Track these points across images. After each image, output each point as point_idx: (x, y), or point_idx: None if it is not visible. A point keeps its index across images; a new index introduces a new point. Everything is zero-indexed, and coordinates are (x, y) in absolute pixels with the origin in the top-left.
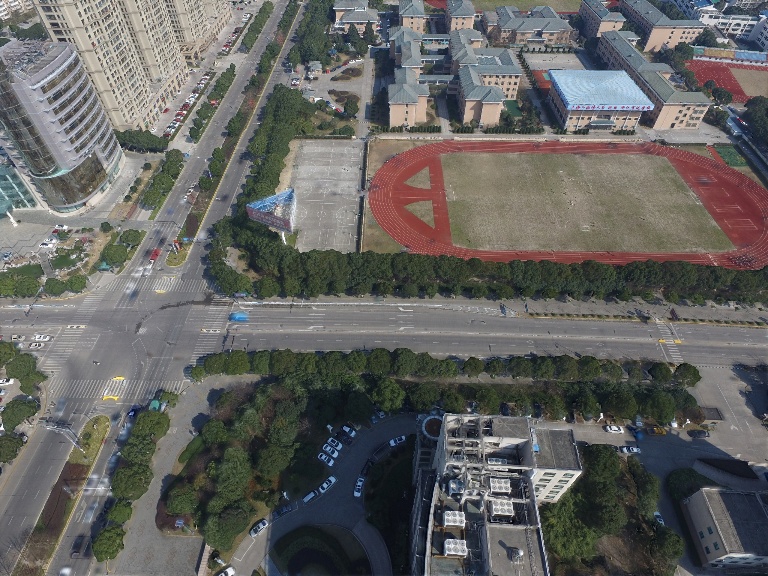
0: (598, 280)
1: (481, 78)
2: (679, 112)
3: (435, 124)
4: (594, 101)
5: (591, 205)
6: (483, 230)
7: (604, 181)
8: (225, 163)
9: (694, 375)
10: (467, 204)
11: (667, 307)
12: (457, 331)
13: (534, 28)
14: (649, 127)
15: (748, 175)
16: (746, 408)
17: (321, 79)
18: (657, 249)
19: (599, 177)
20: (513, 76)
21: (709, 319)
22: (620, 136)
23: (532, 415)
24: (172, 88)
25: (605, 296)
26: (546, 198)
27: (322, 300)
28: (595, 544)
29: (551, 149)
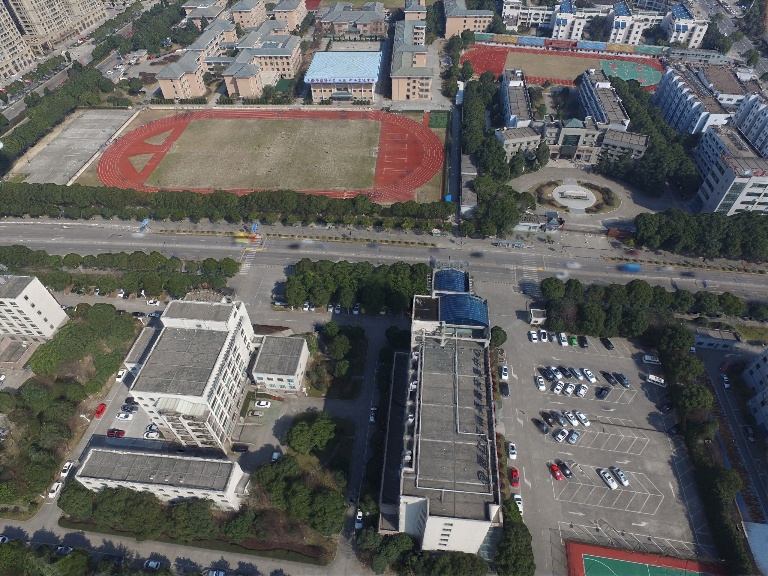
0: (220, 205)
1: (251, 59)
2: (408, 85)
3: (206, 97)
4: (328, 75)
5: (282, 156)
6: (177, 174)
7: (310, 139)
8: (9, 127)
9: (226, 265)
10: (180, 156)
11: (274, 227)
12: (94, 241)
13: (350, 20)
14: (389, 99)
15: (439, 135)
16: (269, 292)
17: (142, 64)
18: (306, 188)
19: (309, 136)
20: (284, 57)
21: (300, 235)
22: (357, 106)
23: (99, 293)
24: (6, 71)
25: (228, 219)
26: (249, 151)
27: (9, 220)
28: (75, 369)
29: (288, 116)
